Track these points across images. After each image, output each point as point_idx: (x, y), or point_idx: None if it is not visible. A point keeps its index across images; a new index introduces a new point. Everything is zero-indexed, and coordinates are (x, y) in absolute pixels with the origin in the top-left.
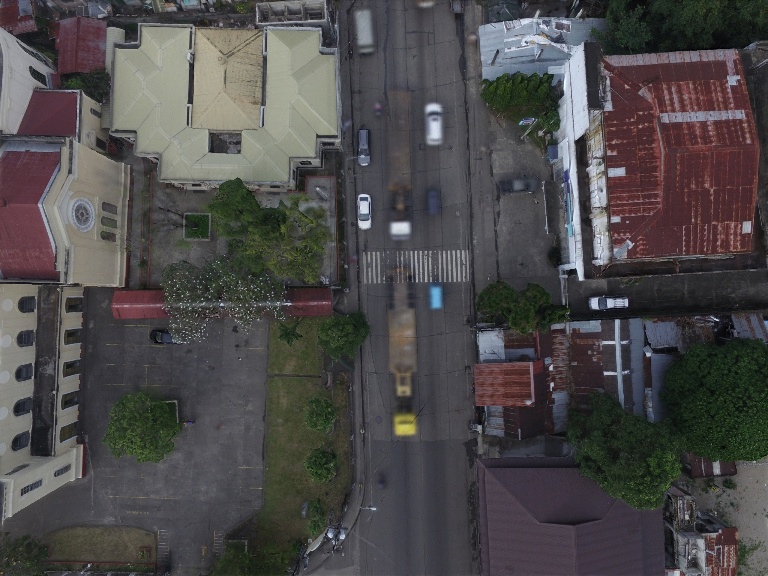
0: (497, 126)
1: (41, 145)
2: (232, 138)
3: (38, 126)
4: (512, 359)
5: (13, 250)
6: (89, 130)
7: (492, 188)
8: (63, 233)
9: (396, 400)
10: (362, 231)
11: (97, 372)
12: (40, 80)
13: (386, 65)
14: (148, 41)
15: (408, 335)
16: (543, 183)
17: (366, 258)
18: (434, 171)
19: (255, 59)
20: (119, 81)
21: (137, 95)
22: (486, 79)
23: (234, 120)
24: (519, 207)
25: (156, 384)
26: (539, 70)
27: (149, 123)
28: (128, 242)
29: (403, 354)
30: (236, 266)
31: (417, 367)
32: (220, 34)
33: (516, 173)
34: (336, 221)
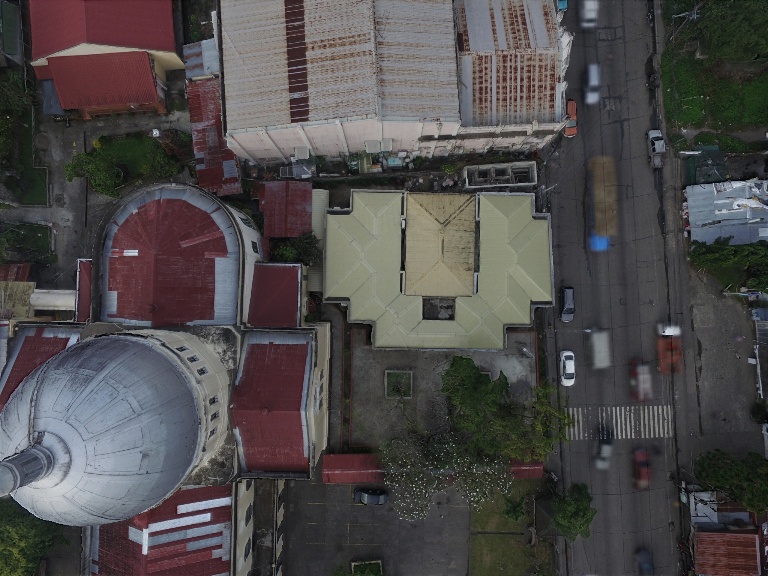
0: (697, 280)
1: (283, 335)
2: (443, 302)
3: (266, 306)
4: (725, 522)
5: (263, 448)
6: (304, 299)
7: (693, 343)
8: (313, 430)
9: (601, 558)
10: (564, 387)
11: (299, 531)
12: (255, 250)
13: (585, 219)
14: (361, 208)
15: (612, 492)
16: (757, 347)
17: (568, 414)
18: (635, 326)
19: (468, 225)
20: (332, 248)
21: (354, 265)
22: (695, 240)
23: (449, 287)
24: (721, 362)
25: (358, 543)
26: (749, 232)
27: (364, 292)
28: (329, 400)
29: (607, 511)
30: (471, 449)
31: (621, 524)
32: (433, 200)
33: (717, 328)
34: (537, 376)
